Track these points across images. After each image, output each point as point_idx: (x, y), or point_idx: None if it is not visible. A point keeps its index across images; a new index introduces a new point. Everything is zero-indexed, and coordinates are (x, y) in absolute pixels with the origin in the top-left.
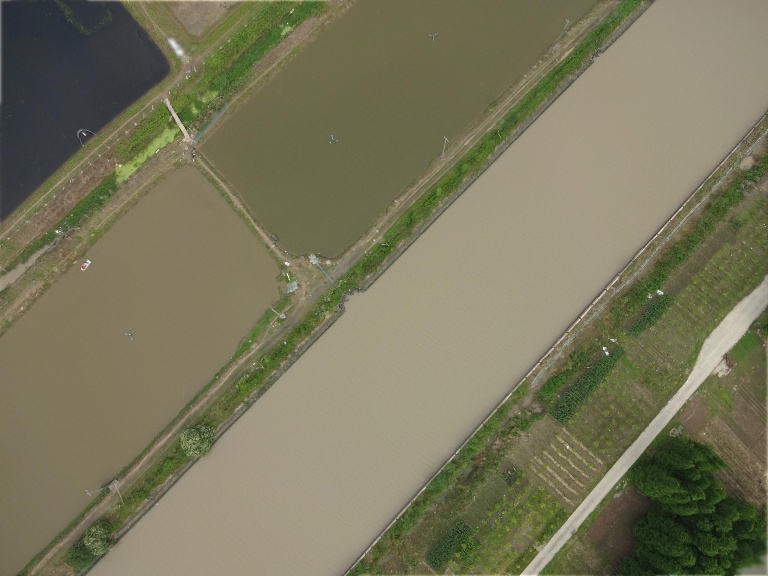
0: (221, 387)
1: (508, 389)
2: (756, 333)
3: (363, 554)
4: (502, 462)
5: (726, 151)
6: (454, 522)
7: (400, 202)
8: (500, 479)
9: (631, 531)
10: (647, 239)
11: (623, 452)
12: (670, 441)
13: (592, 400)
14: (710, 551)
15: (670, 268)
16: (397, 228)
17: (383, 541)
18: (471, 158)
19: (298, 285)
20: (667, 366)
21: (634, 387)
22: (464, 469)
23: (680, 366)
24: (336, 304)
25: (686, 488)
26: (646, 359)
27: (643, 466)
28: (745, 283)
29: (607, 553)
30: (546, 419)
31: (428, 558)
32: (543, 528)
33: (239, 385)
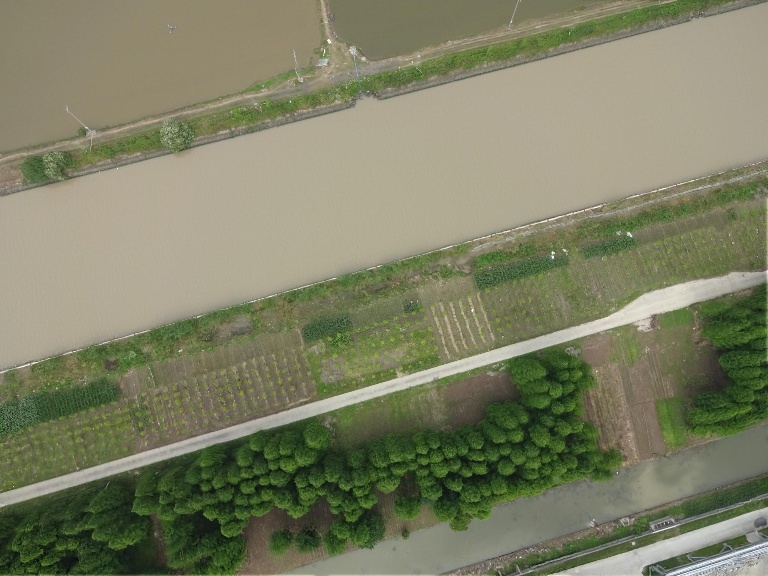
0: (219, 107)
1: (452, 242)
2: (693, 313)
3: (255, 300)
4: (411, 291)
5: (763, 158)
6: (342, 313)
7: (452, 44)
8: (401, 303)
9: (485, 408)
10: (647, 191)
11: (517, 341)
12: (562, 355)
13: (516, 285)
14: (539, 441)
15: (651, 220)
16: (437, 62)
17: (277, 298)
18: (534, 40)
19: (328, 63)
20: (598, 296)
21: (559, 296)
22: (376, 281)
23: (609, 302)
24: (350, 95)
25: (549, 380)
26: (583, 280)
27: (526, 358)
28: (709, 268)
29: (454, 415)
30: (468, 279)
31: (304, 328)
32: (413, 360)
33: (234, 112)
